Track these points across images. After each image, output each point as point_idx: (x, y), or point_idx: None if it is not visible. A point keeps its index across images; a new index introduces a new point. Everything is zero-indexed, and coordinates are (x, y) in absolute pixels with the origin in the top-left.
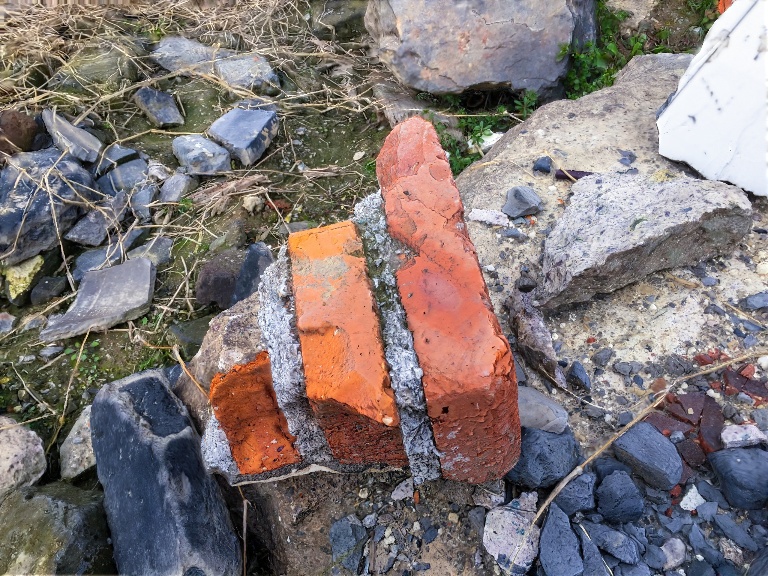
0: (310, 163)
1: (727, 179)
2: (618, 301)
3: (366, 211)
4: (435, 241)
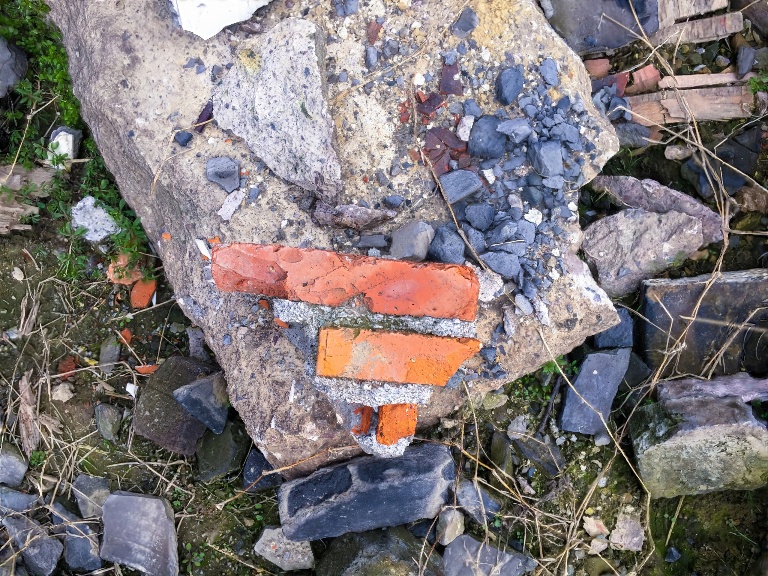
0: (5, 325)
1: (257, 8)
2: (339, 146)
3: (309, 317)
4: (359, 280)
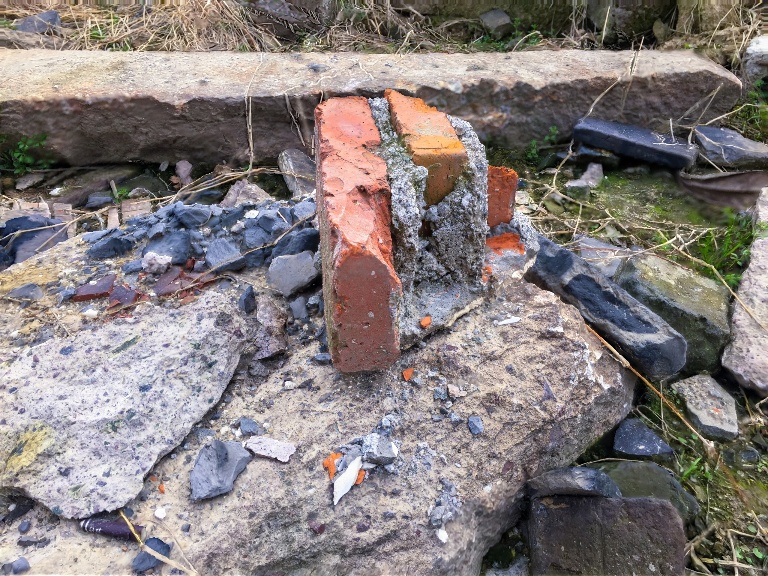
0: None
1: None
2: None
3: None
4: None
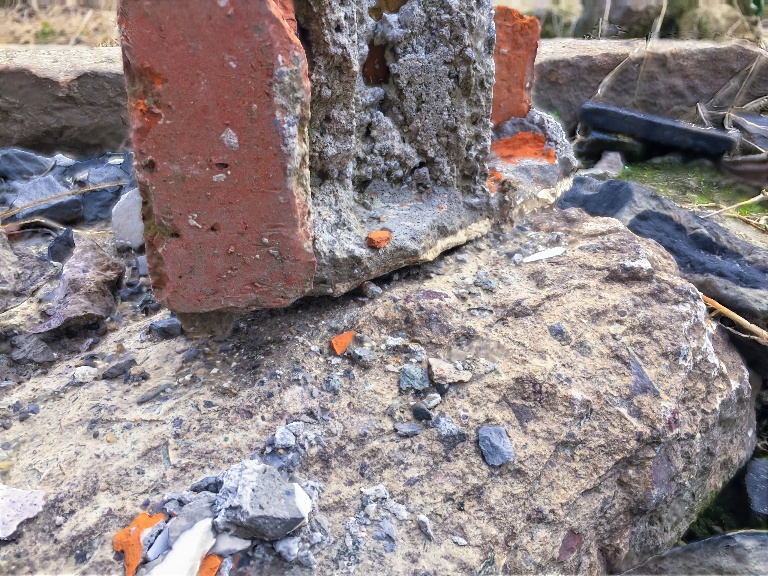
0: None
1: None
2: None
3: None
4: None
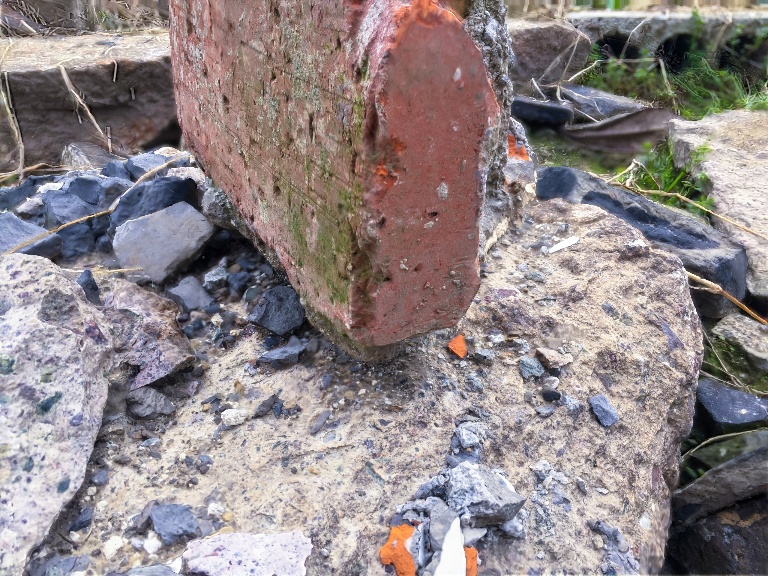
0: None
1: None
2: None
3: None
4: None
